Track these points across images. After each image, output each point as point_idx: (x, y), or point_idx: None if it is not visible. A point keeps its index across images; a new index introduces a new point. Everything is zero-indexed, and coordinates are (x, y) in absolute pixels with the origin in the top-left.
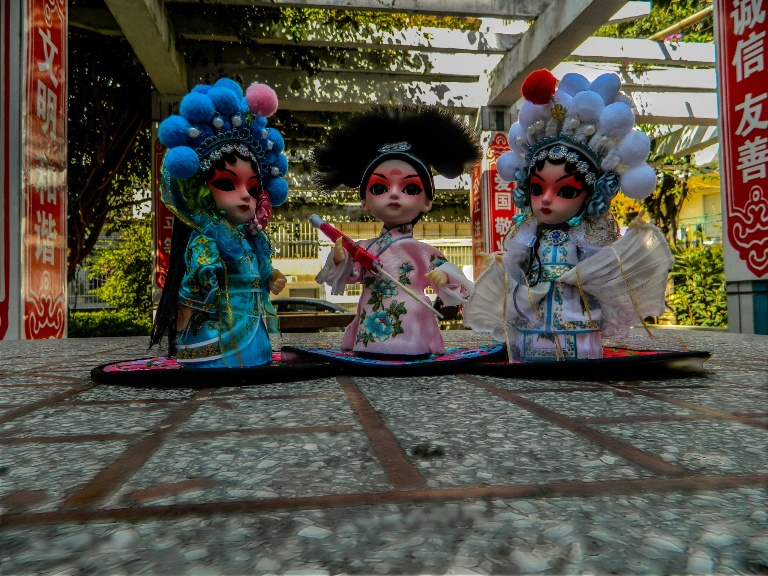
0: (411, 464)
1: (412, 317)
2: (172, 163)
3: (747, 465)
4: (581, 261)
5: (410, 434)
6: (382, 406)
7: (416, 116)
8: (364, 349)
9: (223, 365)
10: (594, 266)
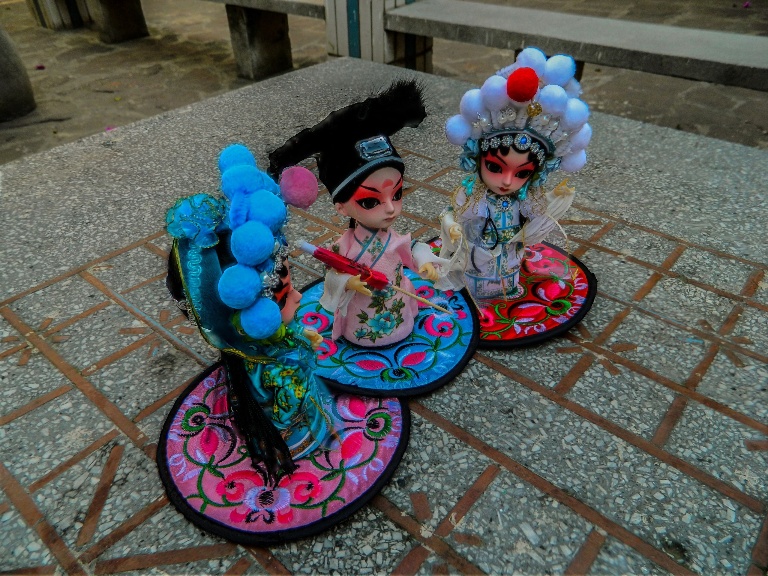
0: (694, 572)
1: (408, 306)
2: (266, 334)
3: (762, 477)
4: (525, 225)
5: (632, 524)
6: (551, 477)
7: (389, 103)
8: (372, 345)
9: (316, 447)
10: (534, 228)
